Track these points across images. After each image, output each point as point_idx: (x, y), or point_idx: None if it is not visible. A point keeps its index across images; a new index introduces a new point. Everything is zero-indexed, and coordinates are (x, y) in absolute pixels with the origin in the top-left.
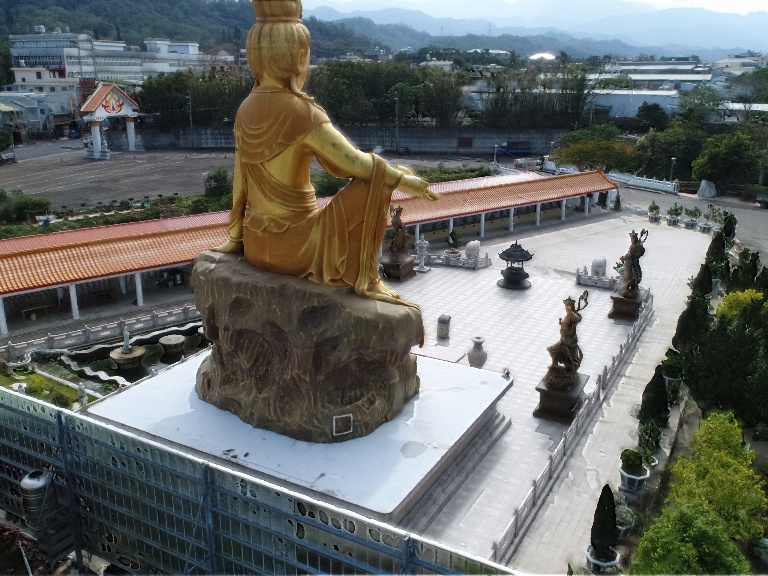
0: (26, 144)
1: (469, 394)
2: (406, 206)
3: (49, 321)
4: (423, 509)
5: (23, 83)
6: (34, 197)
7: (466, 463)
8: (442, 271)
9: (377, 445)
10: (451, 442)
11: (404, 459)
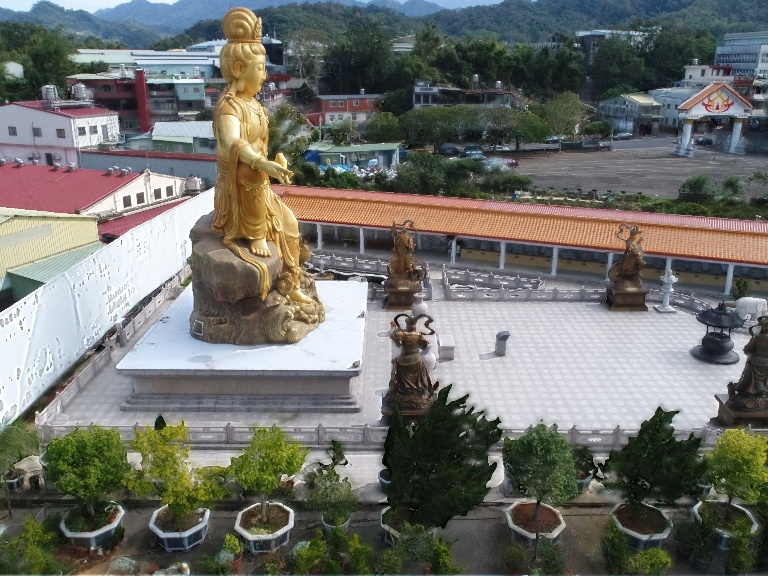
0: (654, 136)
1: (305, 360)
2: (727, 239)
3: (348, 250)
4: (184, 400)
5: (689, 80)
6: (522, 175)
7: (261, 403)
8: (682, 318)
9: (199, 349)
10: (219, 368)
11: (185, 359)
